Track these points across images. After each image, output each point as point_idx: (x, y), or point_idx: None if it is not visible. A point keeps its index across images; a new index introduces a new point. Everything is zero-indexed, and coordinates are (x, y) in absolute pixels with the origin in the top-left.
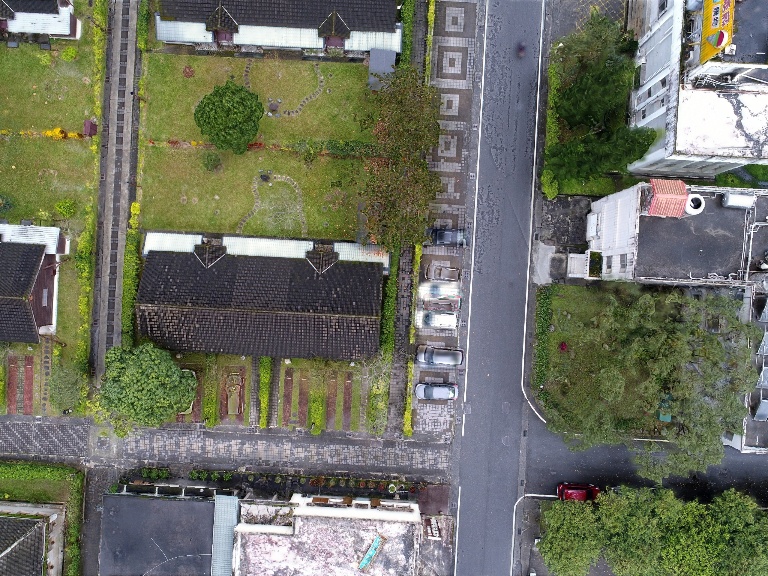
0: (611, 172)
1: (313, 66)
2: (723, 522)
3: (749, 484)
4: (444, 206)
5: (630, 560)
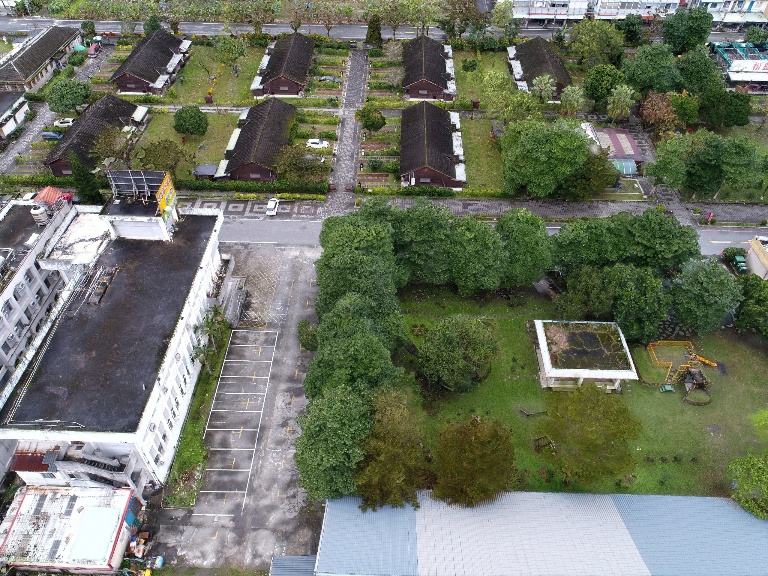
0: None
1: None
2: None
3: None
4: None
5: None
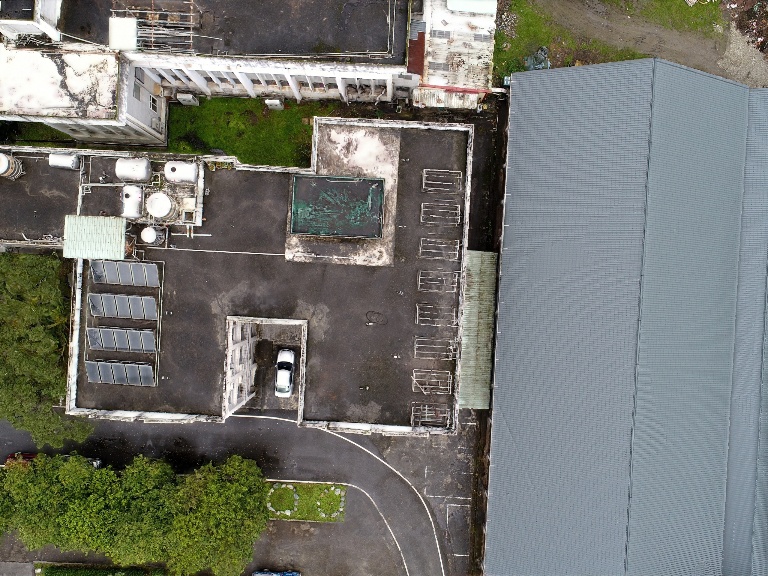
0: (65, 140)
1: None
2: (128, 488)
3: (204, 452)
4: None
5: (27, 527)
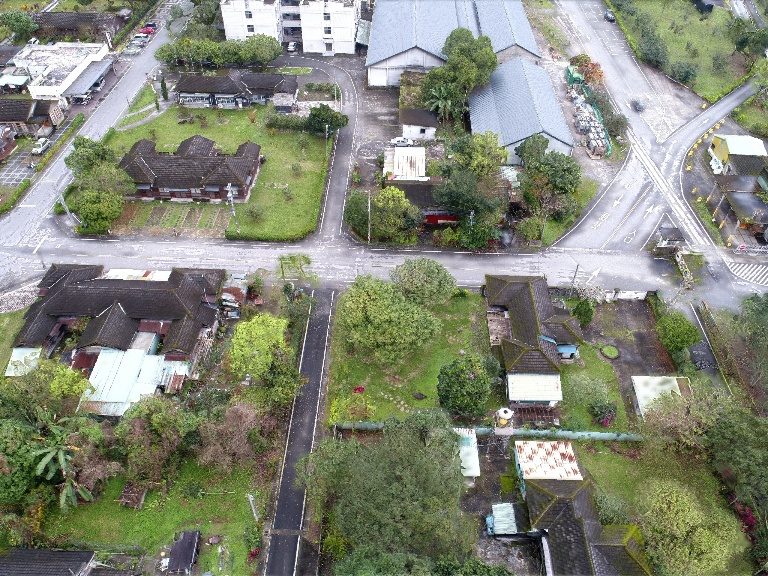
0: None
1: (124, 1)
2: None
3: None
4: (157, 19)
5: None
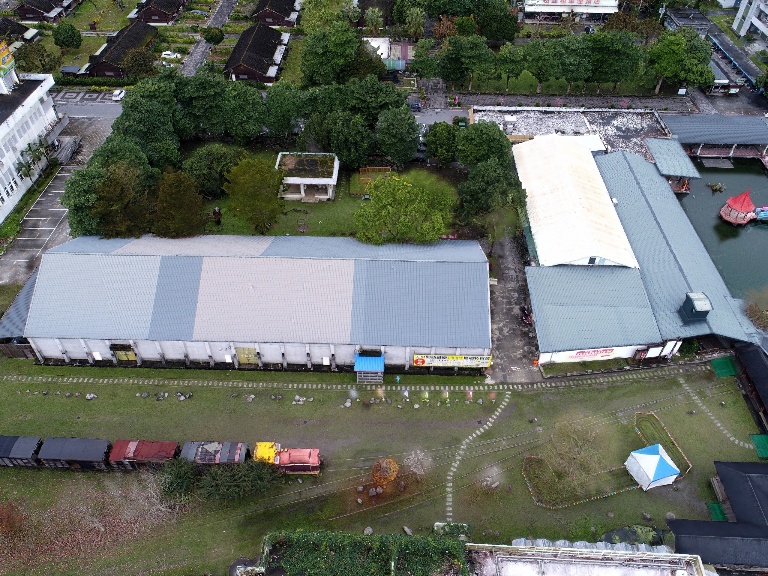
0: None
1: None
2: None
3: None
4: None
5: None
